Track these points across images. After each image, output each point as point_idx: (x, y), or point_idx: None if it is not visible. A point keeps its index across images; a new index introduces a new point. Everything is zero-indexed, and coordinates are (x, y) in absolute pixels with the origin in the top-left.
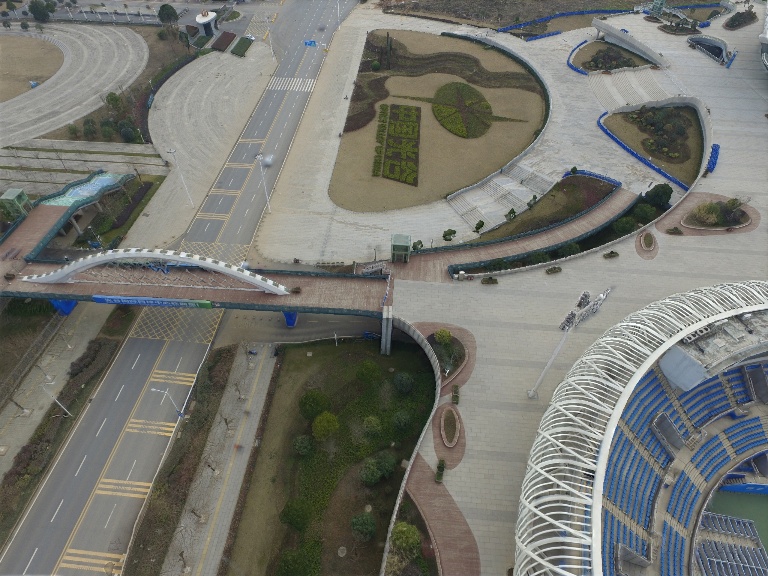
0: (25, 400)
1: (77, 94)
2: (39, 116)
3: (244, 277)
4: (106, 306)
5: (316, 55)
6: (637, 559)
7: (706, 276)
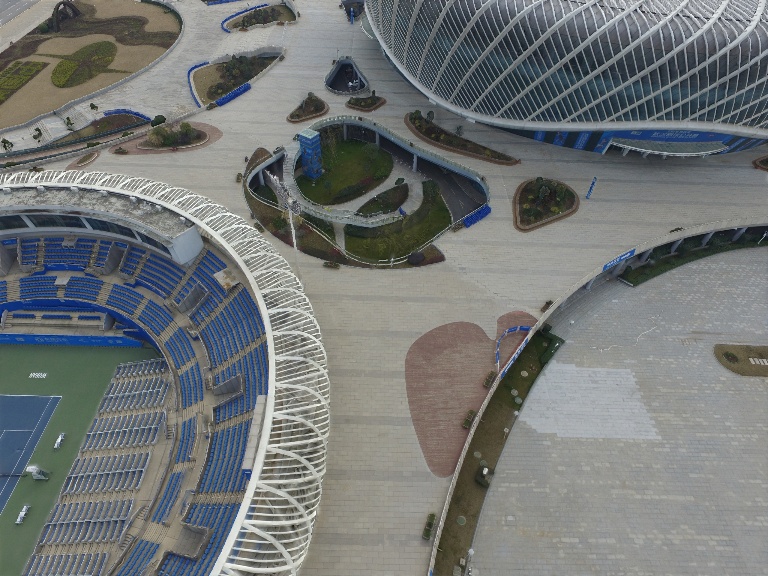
0: None
1: None
2: None
3: None
4: None
5: (1, 21)
6: None
7: None
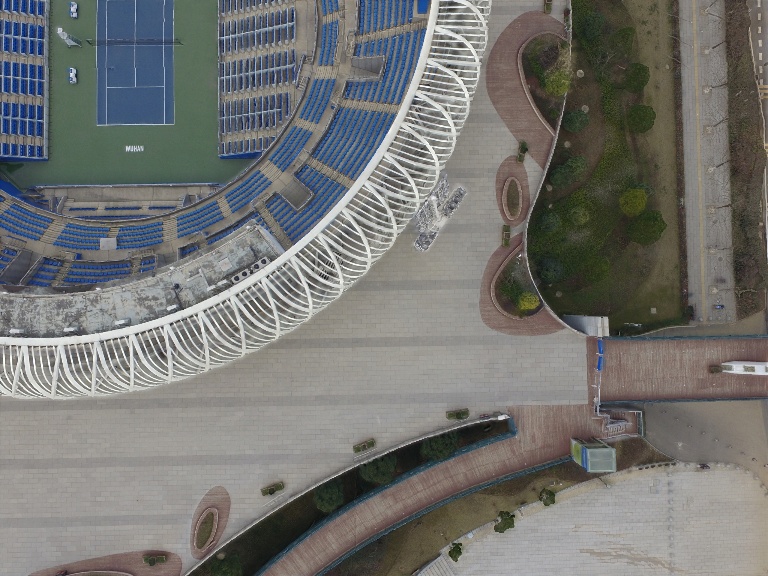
0: None
1: None
2: None
3: None
4: None
5: None
6: None
7: (144, 461)
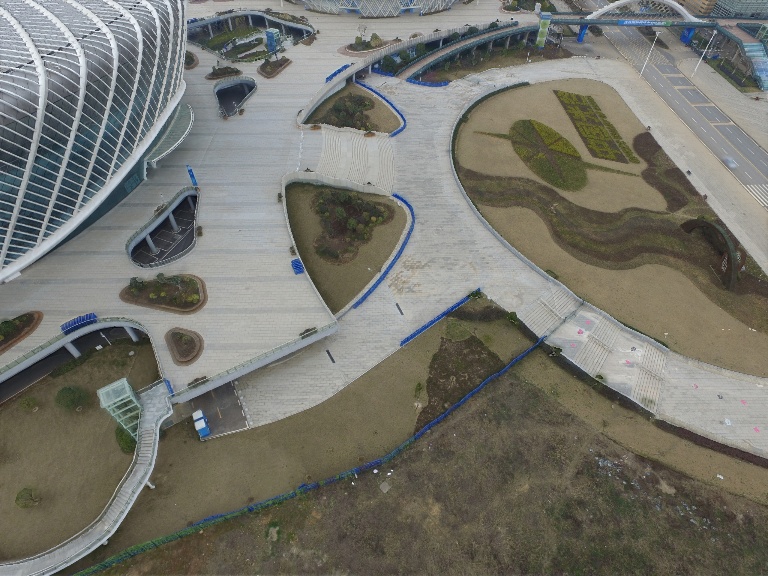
0: None
1: None
2: None
3: None
4: None
5: None
6: None
7: None
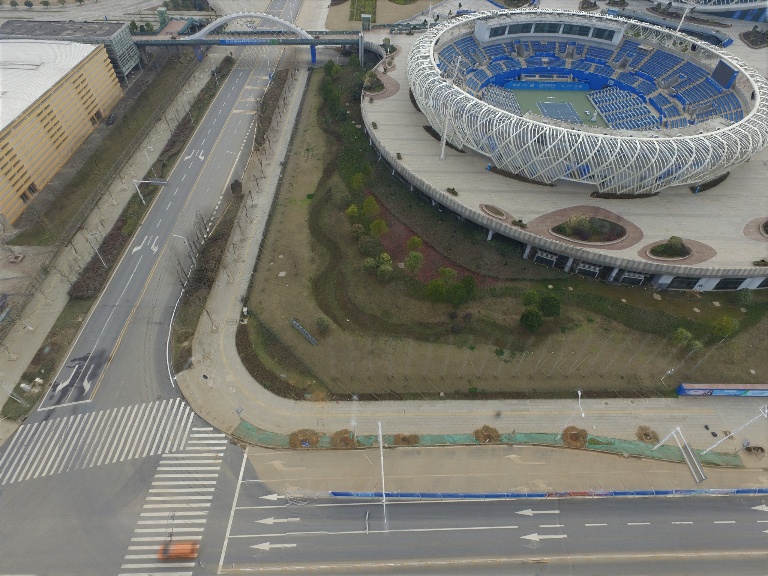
0: (194, 82)
1: None
2: (138, 2)
3: (293, 27)
4: (218, 60)
5: None
6: None
7: None
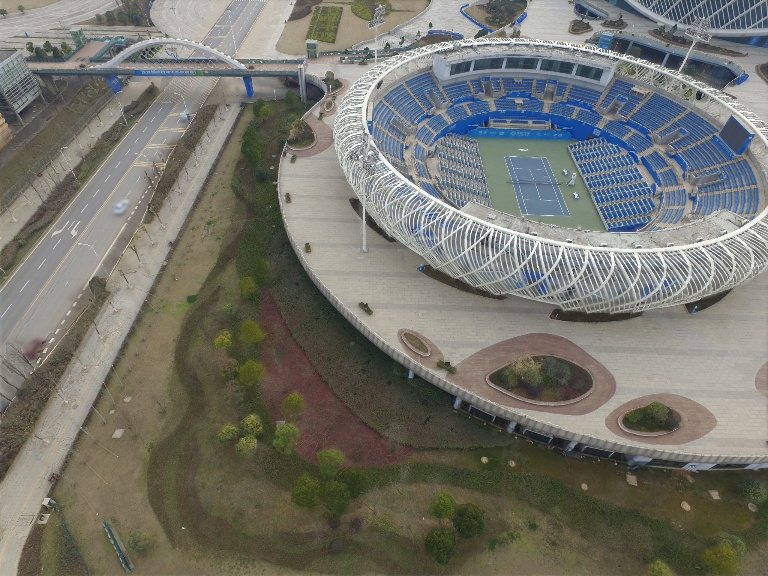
0: None
1: (96, 3)
2: (71, 14)
3: (221, 56)
4: (138, 91)
5: None
6: (404, 128)
7: None
